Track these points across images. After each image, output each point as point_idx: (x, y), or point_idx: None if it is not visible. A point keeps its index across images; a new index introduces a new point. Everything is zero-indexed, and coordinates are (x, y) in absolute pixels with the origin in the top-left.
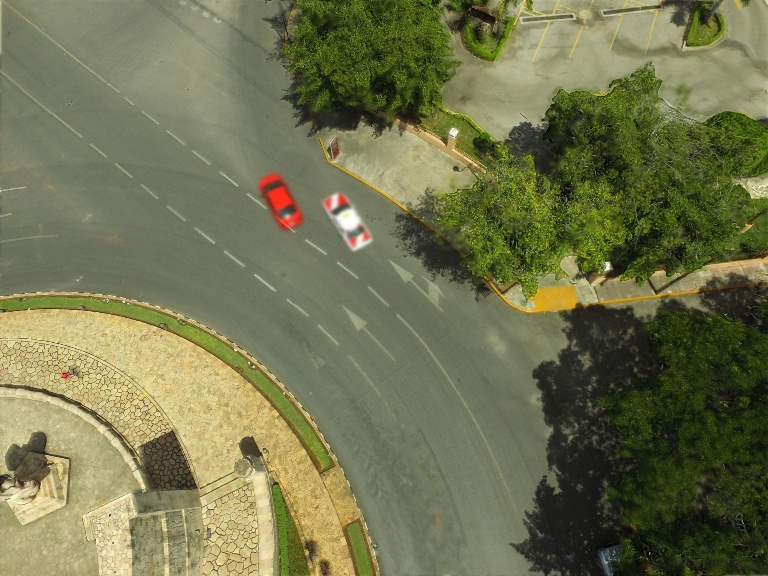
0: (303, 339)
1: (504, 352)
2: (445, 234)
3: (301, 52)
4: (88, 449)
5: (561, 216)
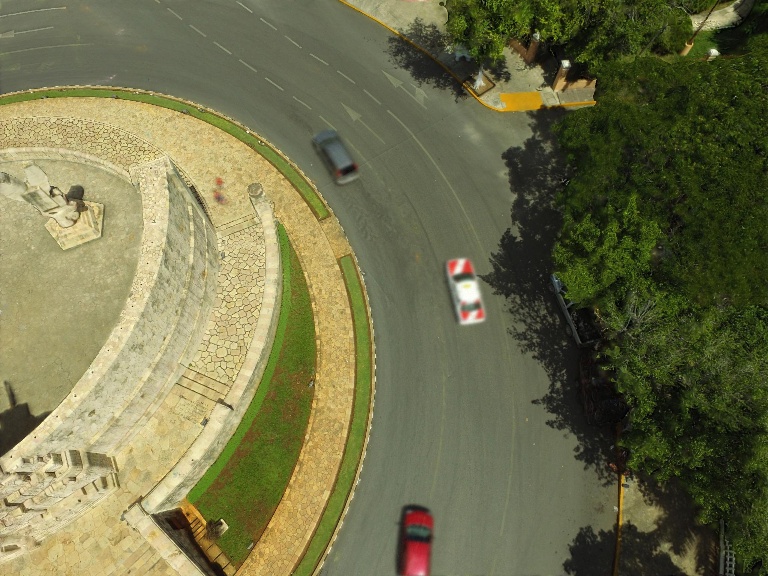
0: (306, 126)
1: (478, 140)
2: (431, 52)
3: None
4: (120, 198)
5: None
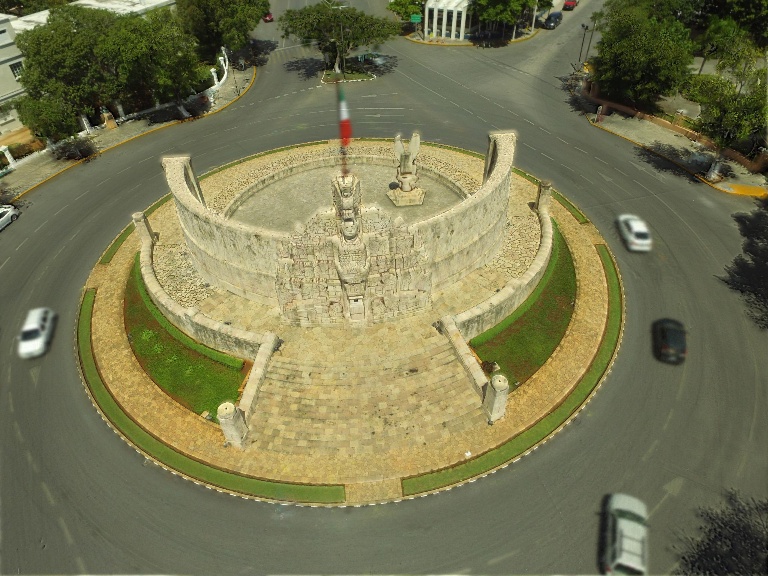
0: (570, 178)
1: (709, 204)
2: (668, 157)
3: (602, 48)
4: (436, 190)
5: (764, 88)
